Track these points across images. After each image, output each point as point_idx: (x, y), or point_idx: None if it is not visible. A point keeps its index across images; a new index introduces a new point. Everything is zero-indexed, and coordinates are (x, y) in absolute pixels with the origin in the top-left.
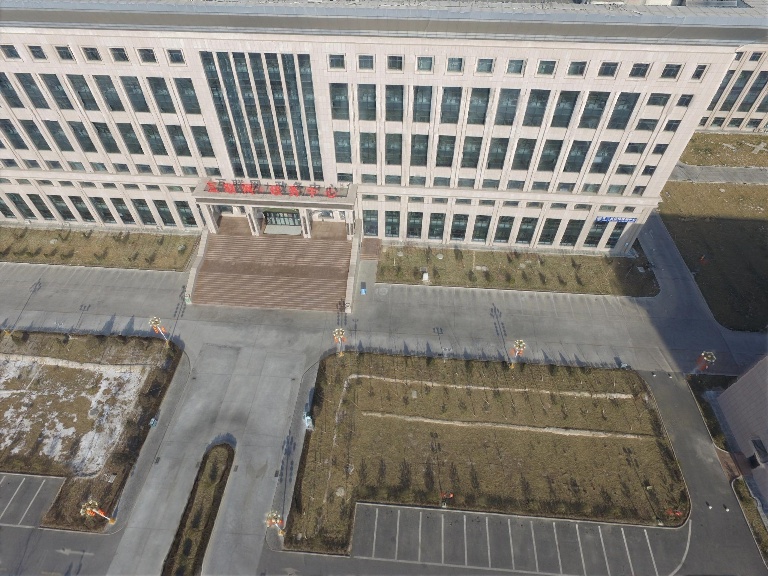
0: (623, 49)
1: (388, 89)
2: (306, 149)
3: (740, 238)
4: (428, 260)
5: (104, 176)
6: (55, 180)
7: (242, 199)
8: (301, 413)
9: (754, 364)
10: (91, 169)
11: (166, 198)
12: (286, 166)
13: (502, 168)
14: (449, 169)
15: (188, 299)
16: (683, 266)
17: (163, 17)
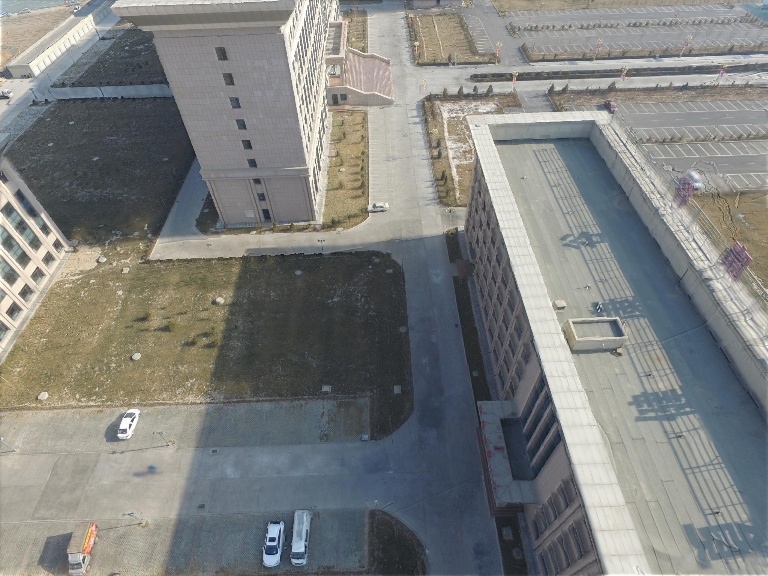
0: None
1: None
2: None
3: None
4: None
5: None
6: None
7: None
8: (449, 67)
9: None
10: None
11: None
12: None
13: None
14: None
15: None
16: None
17: None
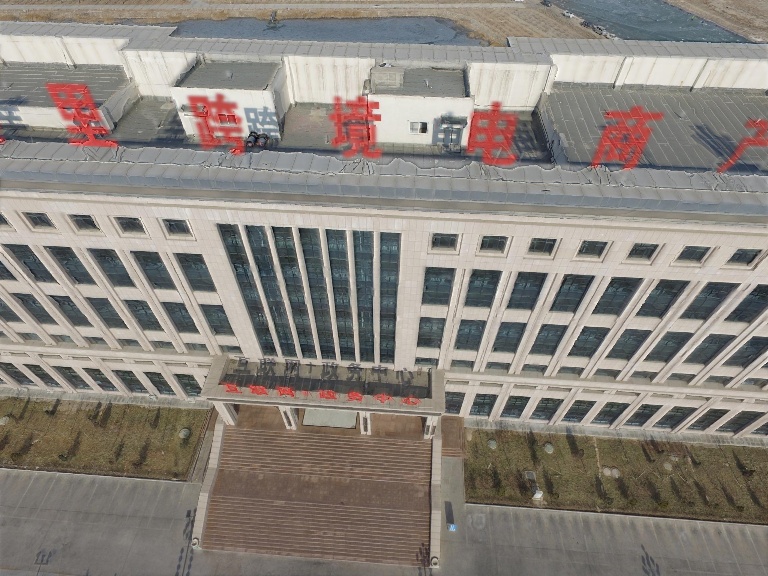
0: None
1: (520, 274)
2: (374, 333)
3: None
4: (535, 459)
5: (72, 350)
6: (1, 351)
7: (276, 401)
8: None
9: None
10: (52, 341)
11: (162, 371)
12: (340, 347)
13: (667, 362)
14: (586, 359)
15: (196, 546)
16: None
17: (157, 190)
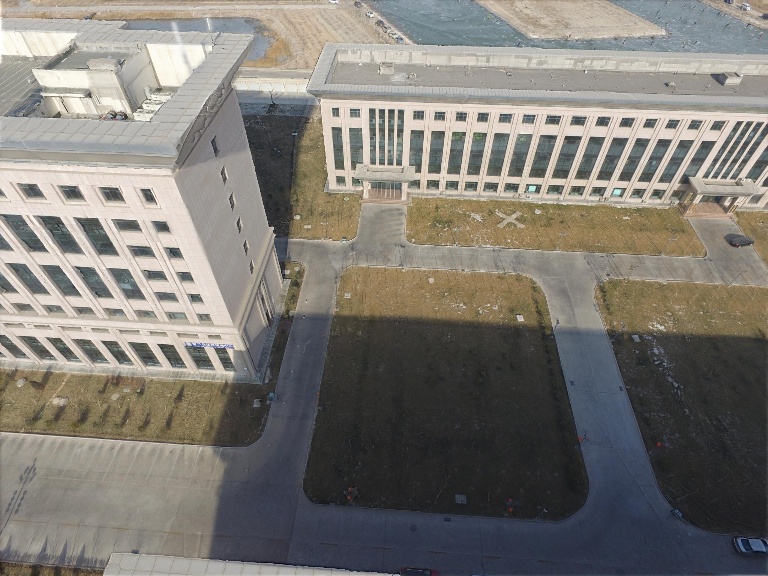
0: (28, 168)
1: None
2: None
3: (412, 352)
4: None
5: None
6: None
7: None
8: None
9: (308, 561)
10: None
11: None
12: None
13: (20, 293)
14: None
15: None
16: (314, 397)
17: None
